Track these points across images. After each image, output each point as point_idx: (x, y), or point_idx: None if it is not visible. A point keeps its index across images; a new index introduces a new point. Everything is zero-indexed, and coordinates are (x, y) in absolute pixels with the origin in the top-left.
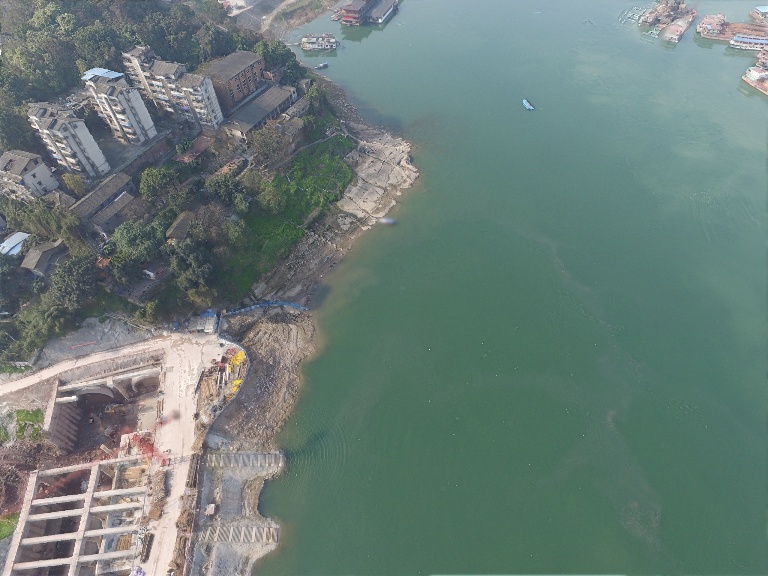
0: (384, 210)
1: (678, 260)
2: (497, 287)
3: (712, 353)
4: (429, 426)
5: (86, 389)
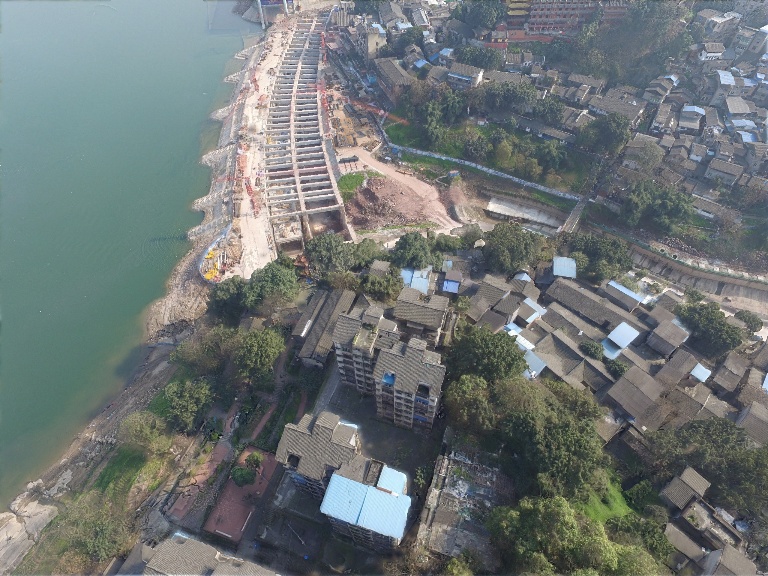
0: None
1: None
2: None
3: None
4: (74, 259)
5: None
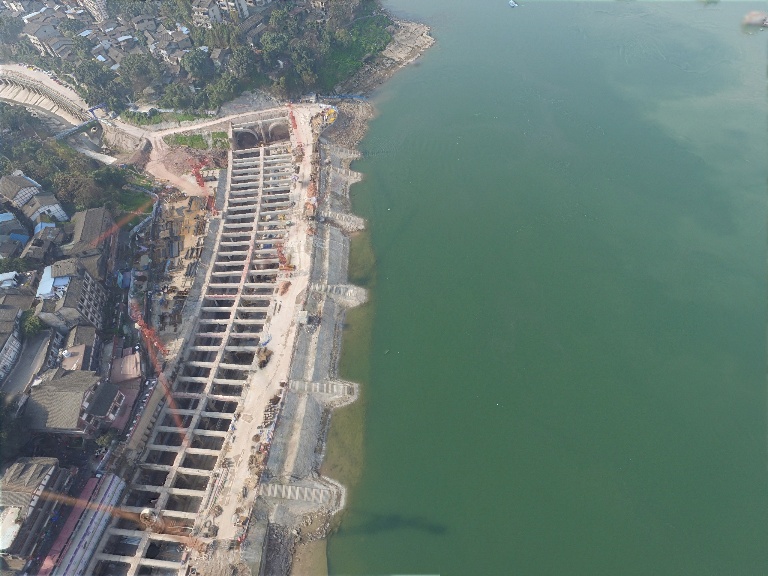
0: (413, 58)
1: (605, 73)
2: (486, 88)
3: (617, 112)
4: (443, 141)
5: (245, 129)
